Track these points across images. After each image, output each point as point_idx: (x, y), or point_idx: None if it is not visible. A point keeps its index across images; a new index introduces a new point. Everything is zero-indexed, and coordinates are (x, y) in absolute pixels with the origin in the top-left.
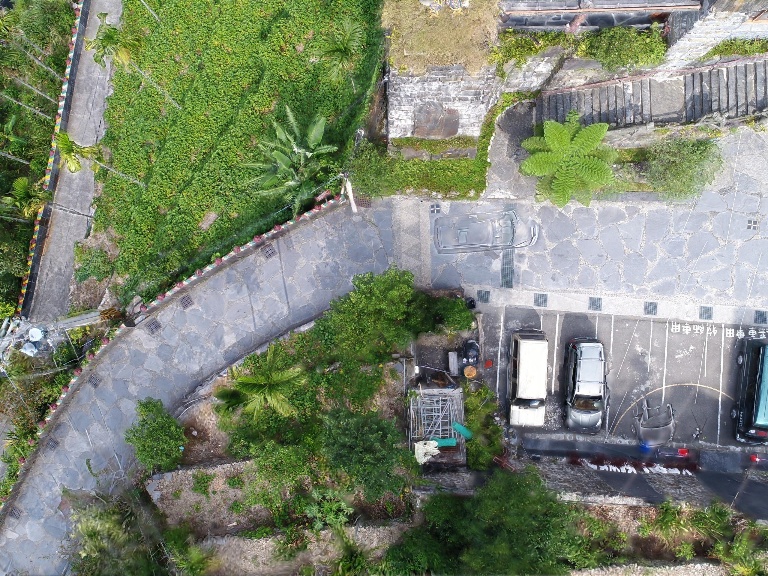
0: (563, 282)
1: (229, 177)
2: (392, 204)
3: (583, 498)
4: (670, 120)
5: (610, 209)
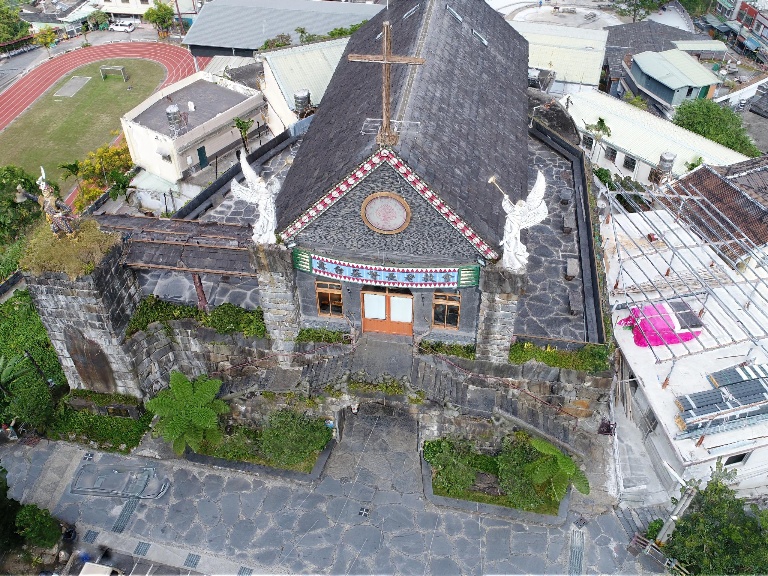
0: (171, 535)
1: None
2: (54, 448)
3: None
4: None
5: (239, 480)
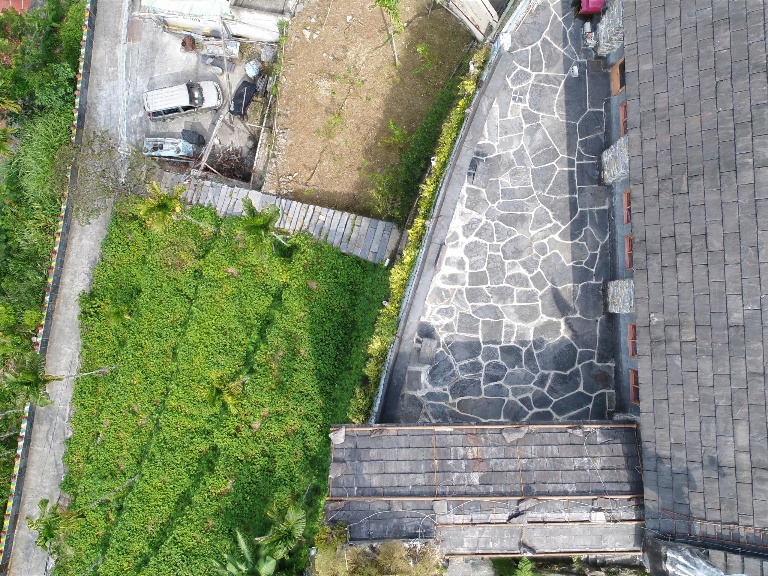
0: None
1: (185, 566)
2: None
3: None
4: (624, 562)
5: None
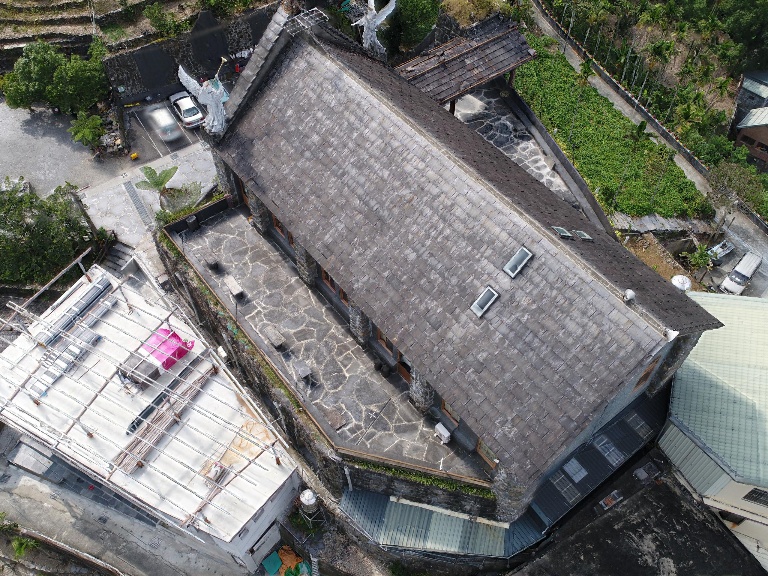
0: None
1: None
2: None
3: (280, 0)
4: None
5: None
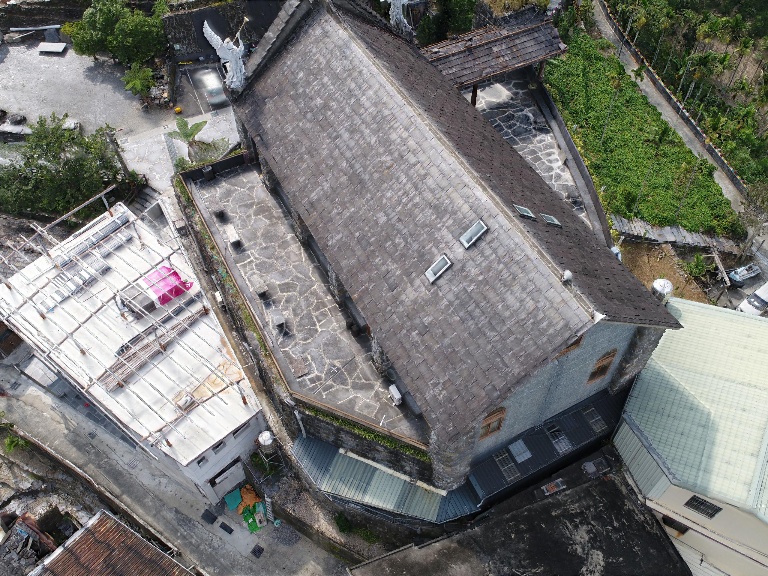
0: None
1: None
2: None
3: None
4: None
5: None
